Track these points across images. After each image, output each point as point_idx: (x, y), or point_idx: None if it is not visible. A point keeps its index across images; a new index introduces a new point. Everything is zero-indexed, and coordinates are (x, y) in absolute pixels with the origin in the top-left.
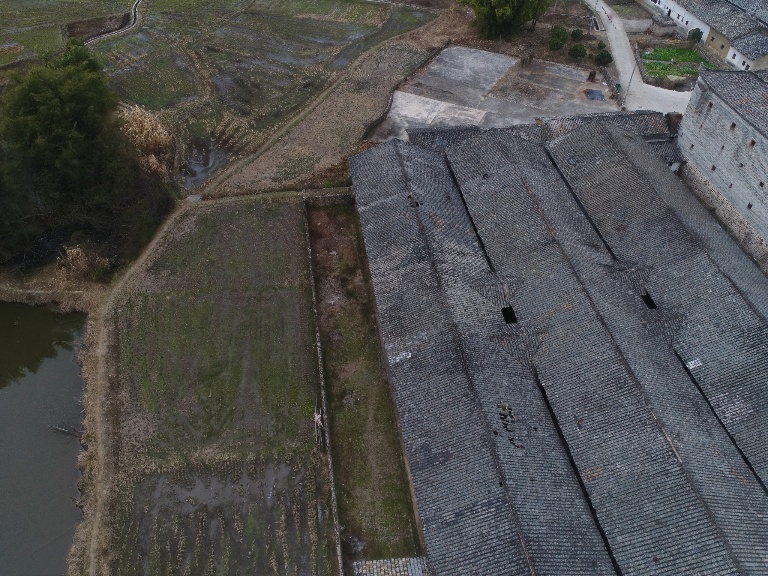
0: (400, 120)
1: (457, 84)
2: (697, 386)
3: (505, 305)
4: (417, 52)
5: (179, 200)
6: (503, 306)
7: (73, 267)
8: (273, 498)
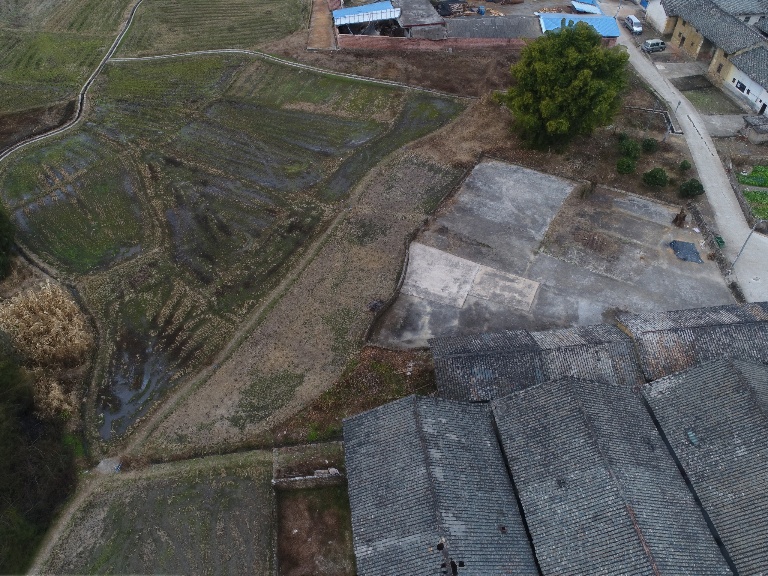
0: (419, 299)
1: (496, 230)
2: None
3: None
4: (440, 169)
5: (85, 472)
6: None
7: None
8: None
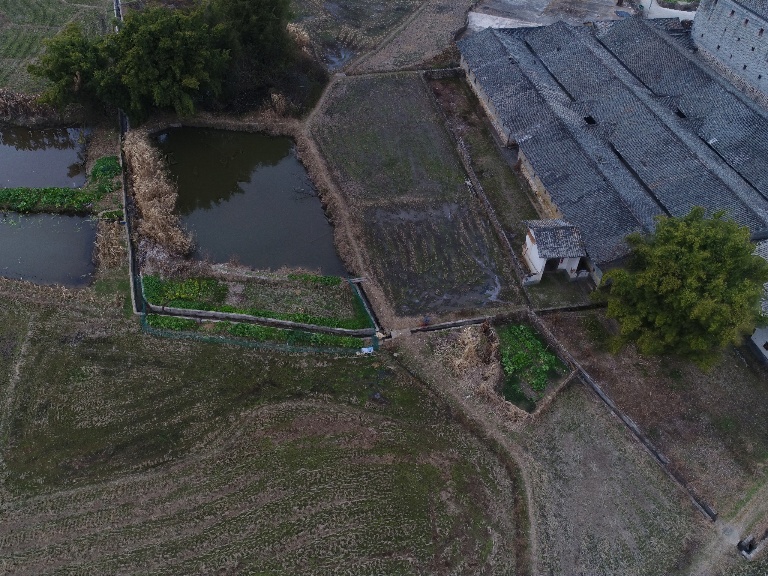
0: (478, 30)
1: (516, 8)
2: (715, 151)
3: (586, 116)
4: None
5: (330, 75)
6: (585, 116)
7: (277, 107)
8: (452, 217)
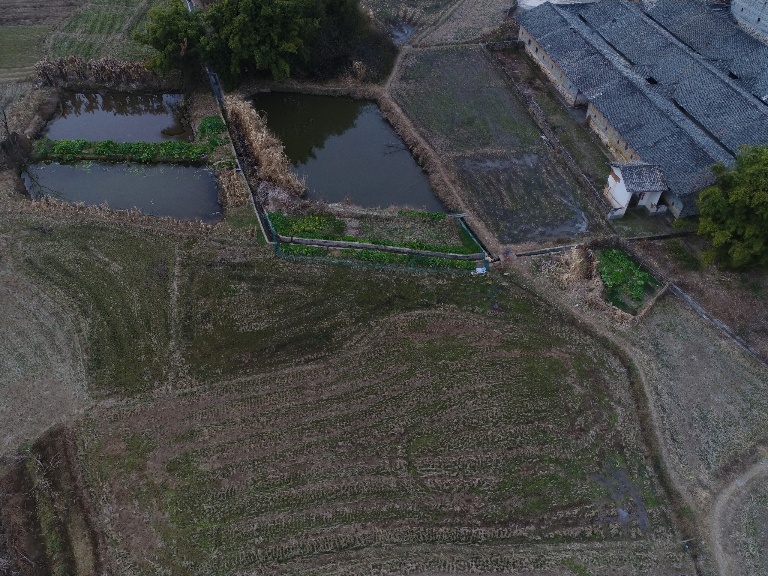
0: (528, 8)
1: None
2: None
3: (647, 77)
4: None
5: (399, 48)
6: (646, 78)
7: (358, 73)
8: (534, 165)
